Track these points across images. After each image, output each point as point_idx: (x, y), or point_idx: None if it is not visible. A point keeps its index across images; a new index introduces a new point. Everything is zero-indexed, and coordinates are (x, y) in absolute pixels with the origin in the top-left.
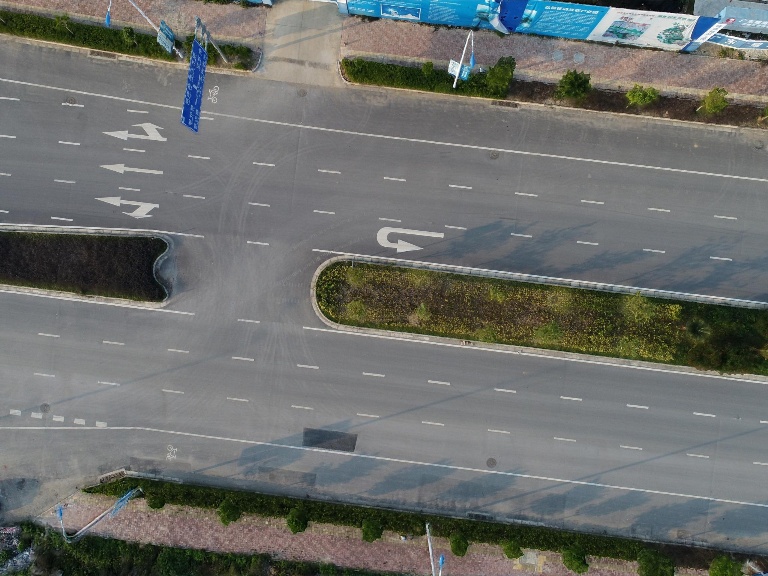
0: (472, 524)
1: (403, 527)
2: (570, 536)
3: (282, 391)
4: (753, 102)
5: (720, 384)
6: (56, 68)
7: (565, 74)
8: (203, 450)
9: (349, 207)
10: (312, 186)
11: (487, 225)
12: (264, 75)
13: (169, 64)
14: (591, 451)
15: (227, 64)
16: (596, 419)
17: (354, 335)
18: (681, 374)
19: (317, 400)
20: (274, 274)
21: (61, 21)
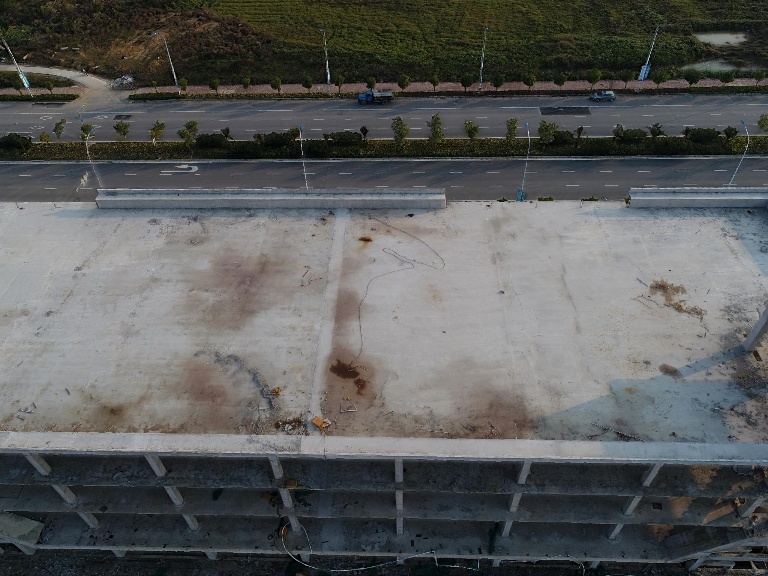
0: None
1: None
2: (725, 90)
3: None
4: None
5: None
6: None
7: None
8: None
9: None
10: None
11: None
12: None
13: None
14: None
15: None
16: None
17: None
18: None
19: None
20: None
21: None
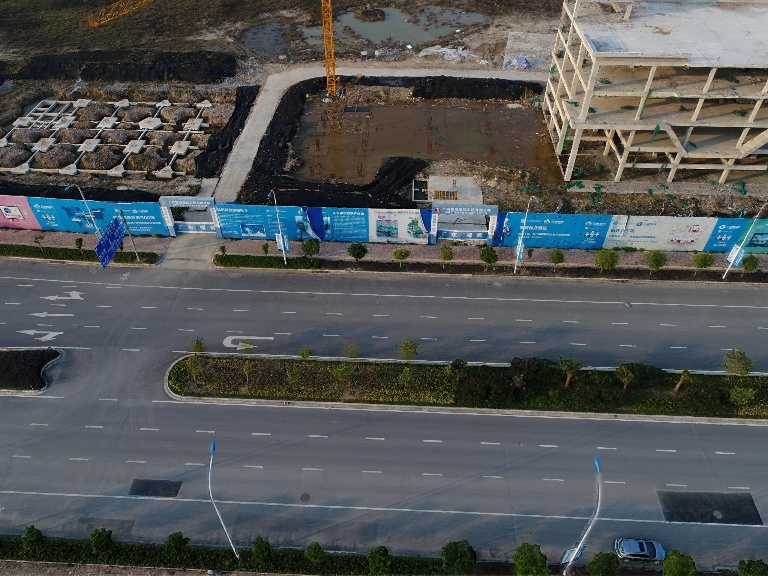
0: (282, 553)
1: (211, 561)
2: None
3: (121, 450)
4: (479, 263)
5: (498, 420)
6: (23, 269)
7: None
8: (30, 506)
9: (206, 327)
10: (181, 317)
11: (306, 331)
12: (162, 266)
13: (100, 264)
14: (396, 480)
15: (139, 262)
16: (398, 453)
17: (194, 404)
18: (464, 415)
19: (151, 455)
20: (138, 368)
21: (38, 240)
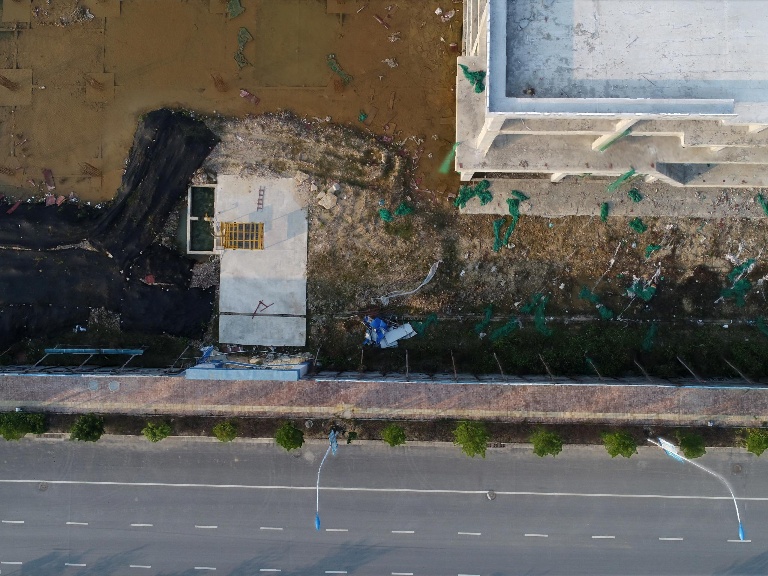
0: None
1: None
2: None
3: None
4: (285, 413)
5: None
6: None
7: (102, 403)
8: None
9: None
10: None
11: (42, 557)
12: None
13: None
14: None
15: None
16: None
17: None
18: None
19: None
20: None
21: None
